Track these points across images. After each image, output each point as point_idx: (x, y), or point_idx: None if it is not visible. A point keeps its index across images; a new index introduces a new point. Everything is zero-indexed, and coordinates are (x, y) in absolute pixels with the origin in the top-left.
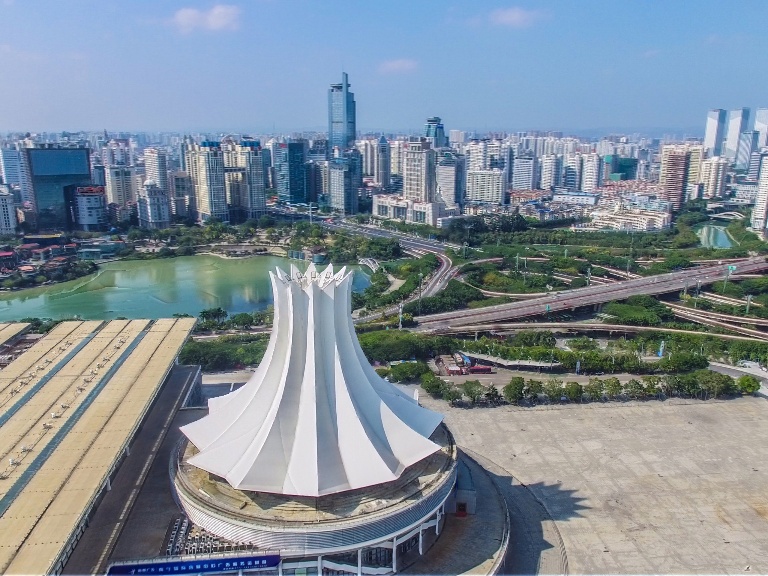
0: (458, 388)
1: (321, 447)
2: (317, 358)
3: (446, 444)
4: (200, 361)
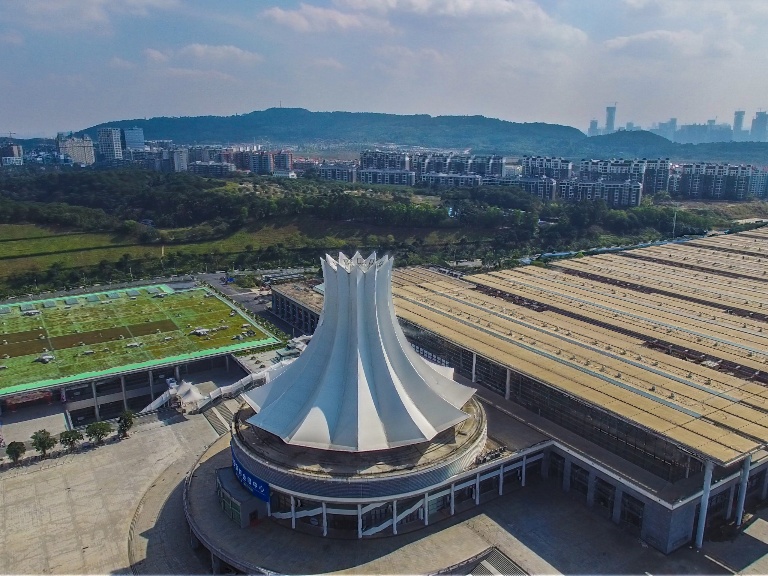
0: None
1: None
2: None
3: None
4: None
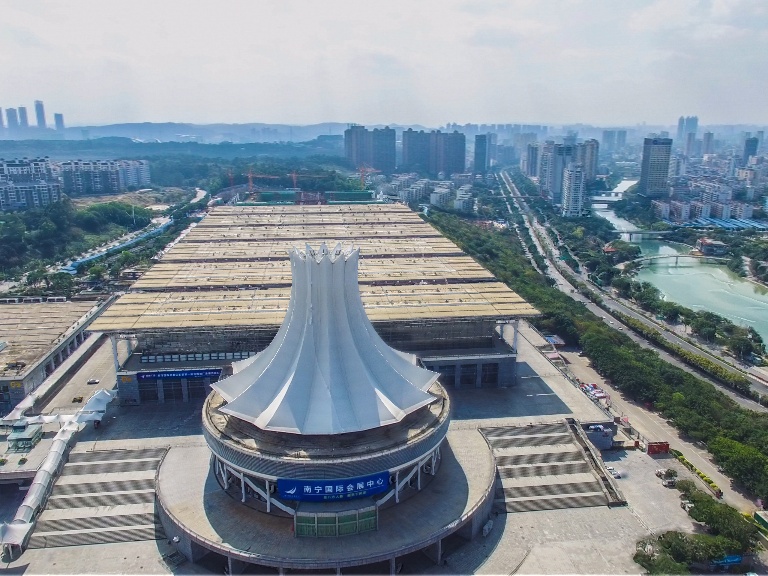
0: (656, 557)
1: (249, 369)
2: (290, 313)
3: (309, 452)
4: (620, 378)
